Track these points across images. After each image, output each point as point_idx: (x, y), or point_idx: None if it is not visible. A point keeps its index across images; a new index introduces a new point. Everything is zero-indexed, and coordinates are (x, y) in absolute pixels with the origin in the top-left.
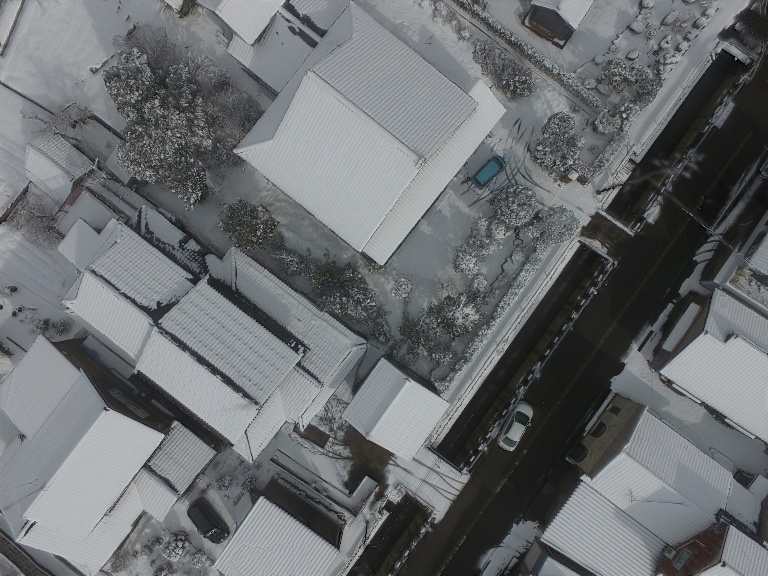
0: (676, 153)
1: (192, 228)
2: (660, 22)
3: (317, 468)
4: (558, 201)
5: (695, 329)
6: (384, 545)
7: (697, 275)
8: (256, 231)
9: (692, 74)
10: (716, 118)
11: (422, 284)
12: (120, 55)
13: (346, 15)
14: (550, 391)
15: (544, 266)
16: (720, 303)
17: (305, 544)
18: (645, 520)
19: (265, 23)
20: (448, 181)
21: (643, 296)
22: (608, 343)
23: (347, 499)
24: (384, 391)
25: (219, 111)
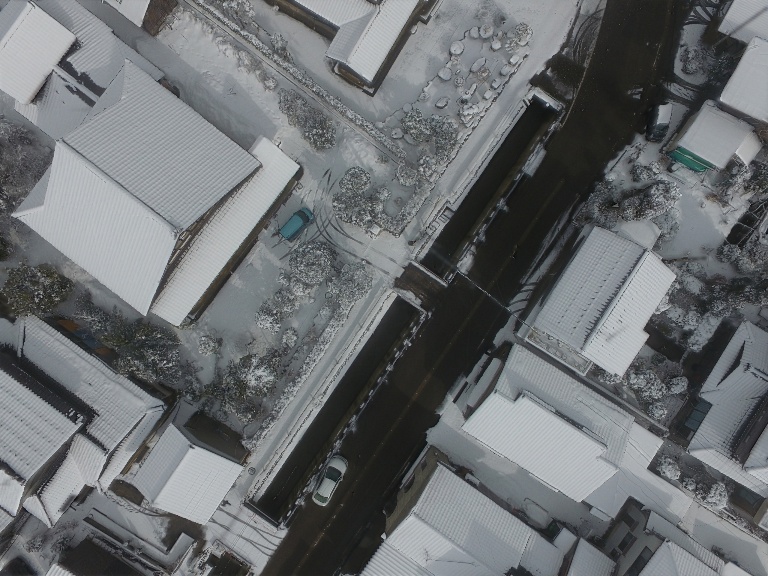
0: (492, 200)
1: None
2: (469, 68)
3: (134, 526)
4: (370, 252)
5: (494, 385)
6: None
7: (511, 325)
8: (33, 298)
9: (504, 121)
10: (528, 166)
11: (233, 339)
12: None
13: (121, 74)
14: (366, 444)
15: (358, 318)
16: (517, 359)
17: None
18: None
19: (40, 83)
20: (242, 239)
21: (457, 347)
22: (423, 395)
23: (164, 556)
24: (170, 457)
25: (7, 171)
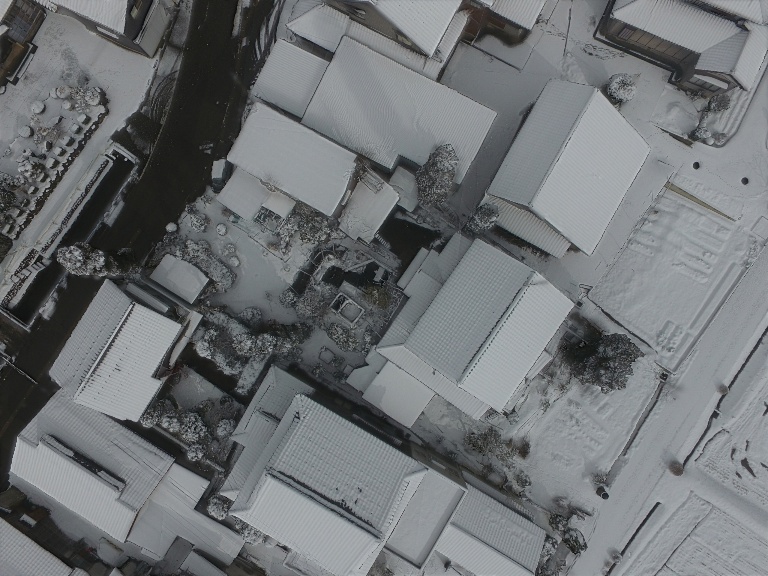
0: None
1: None
2: None
3: None
4: None
5: None
6: None
7: None
8: None
9: (86, 175)
10: (108, 216)
11: None
12: None
13: None
14: None
15: None
16: (56, 404)
17: None
18: None
19: None
20: None
21: (39, 390)
22: (6, 436)
23: None
24: None
25: None
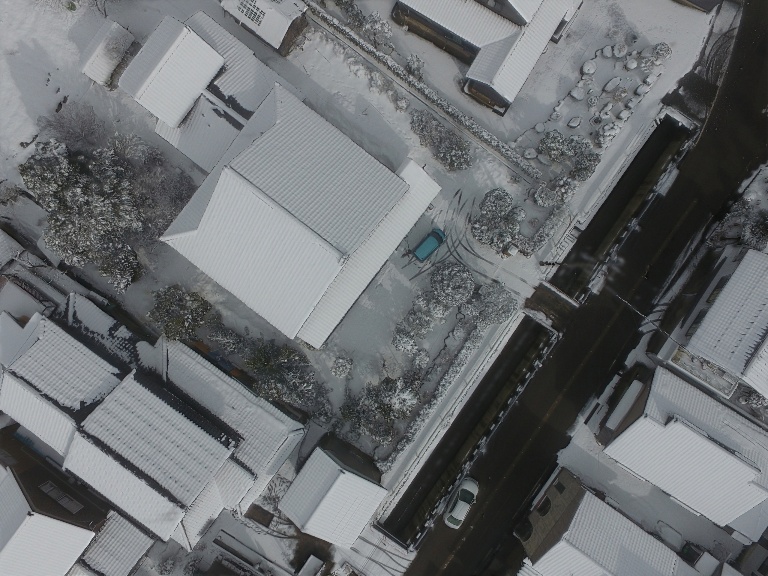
0: (621, 220)
1: (128, 307)
2: (602, 88)
3: (262, 548)
4: (501, 273)
5: (637, 408)
6: None
7: (643, 346)
8: (184, 322)
9: (636, 140)
10: (661, 185)
11: (364, 360)
12: (37, 146)
13: (271, 98)
14: (496, 466)
15: (488, 339)
16: (662, 382)
17: None
18: None
19: (189, 107)
20: (384, 261)
21: (589, 368)
22: (554, 416)
23: None
24: (319, 482)
25: (148, 193)
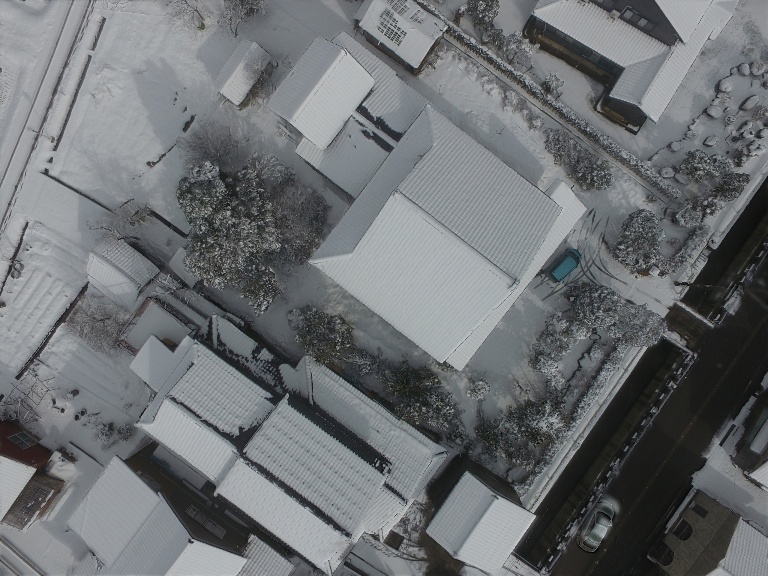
0: (755, 239)
1: (258, 328)
2: (738, 106)
3: (391, 570)
4: (635, 293)
5: None
6: None
7: None
8: (335, 346)
9: None
10: None
11: (497, 382)
12: (192, 169)
13: (423, 120)
14: (630, 488)
15: None
16: None
17: None
18: None
19: (339, 128)
20: (527, 283)
21: (724, 389)
22: (689, 438)
23: None
24: (470, 508)
25: (289, 215)
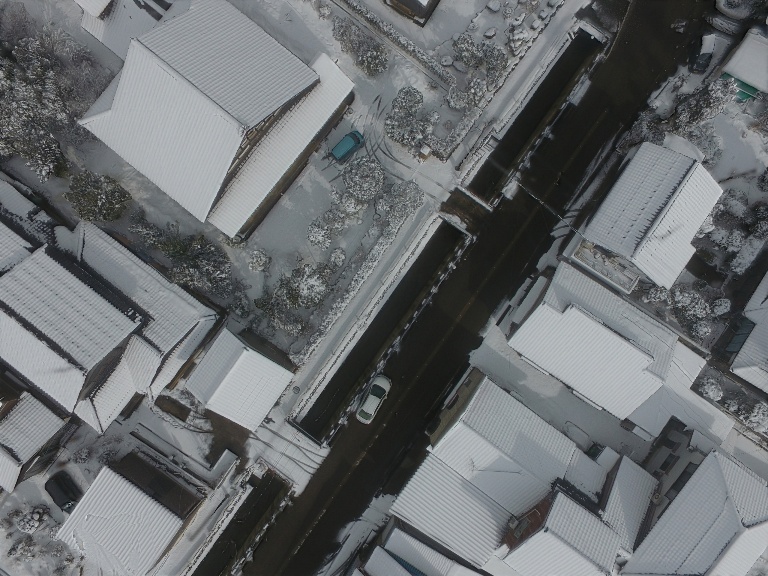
0: (537, 130)
1: (55, 202)
2: (517, 1)
3: (178, 442)
4: (418, 177)
5: (540, 301)
6: (250, 520)
7: (554, 250)
8: (97, 201)
9: (550, 52)
10: (573, 95)
11: (282, 258)
12: None
13: None
14: (409, 365)
15: (404, 241)
16: (563, 275)
17: (148, 514)
18: (489, 490)
19: None
20: (297, 154)
21: (501, 271)
22: (467, 317)
23: (207, 472)
24: (224, 360)
25: (72, 84)
